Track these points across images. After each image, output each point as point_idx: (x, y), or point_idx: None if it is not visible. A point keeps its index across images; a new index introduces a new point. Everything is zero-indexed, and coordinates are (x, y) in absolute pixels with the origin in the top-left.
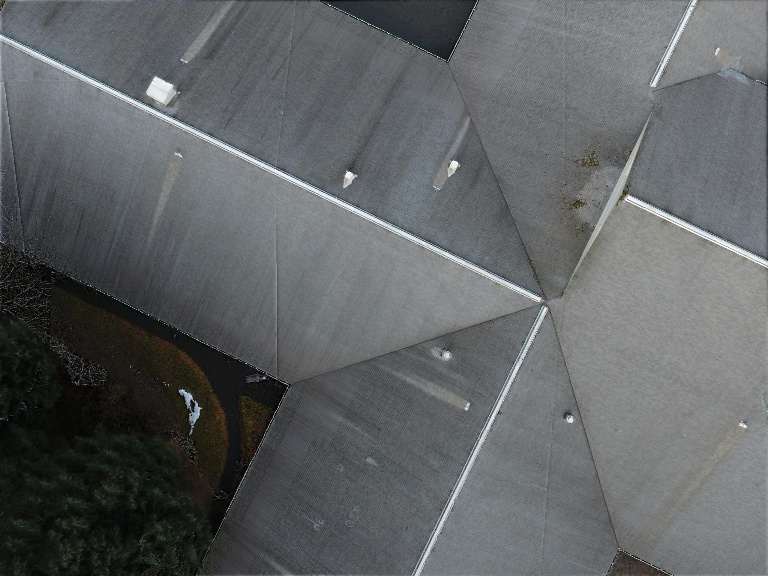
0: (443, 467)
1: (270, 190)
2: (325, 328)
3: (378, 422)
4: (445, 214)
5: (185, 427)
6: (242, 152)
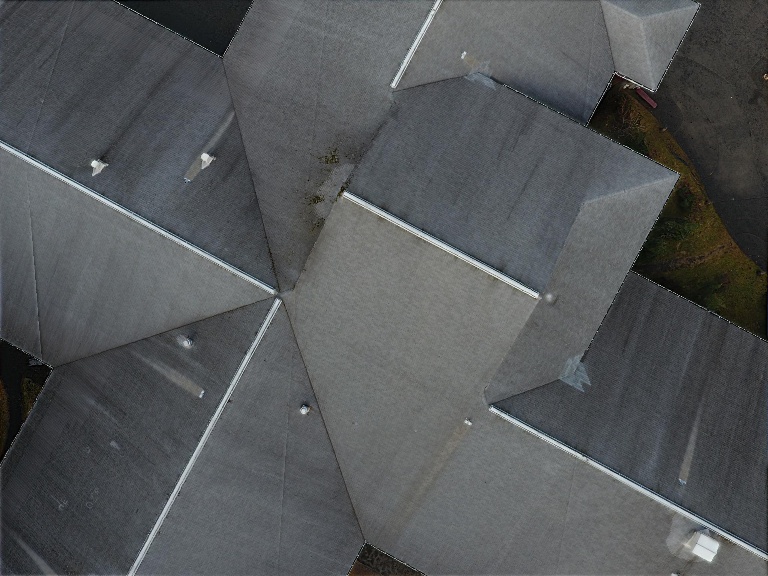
0: (174, 452)
1: (22, 176)
2: (81, 313)
3: (124, 407)
4: (191, 205)
5: None
6: None
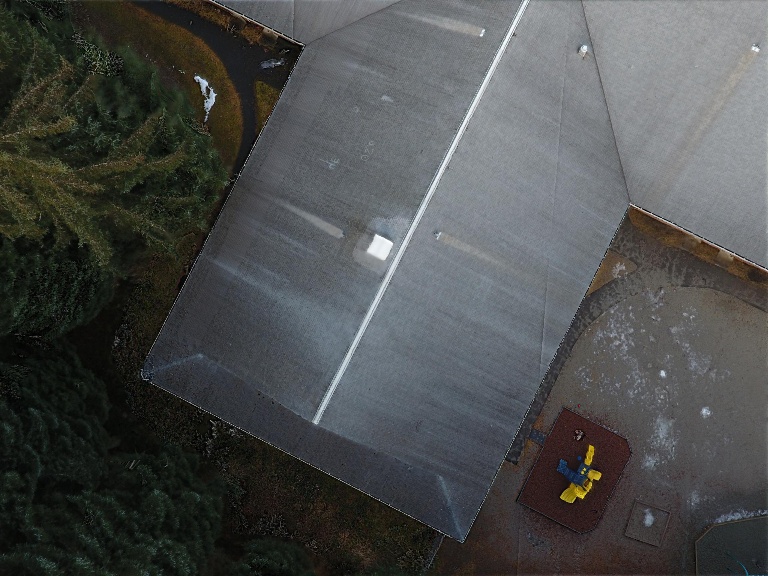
0: (458, 91)
1: None
2: None
3: (393, 62)
4: None
5: (200, 114)
6: None
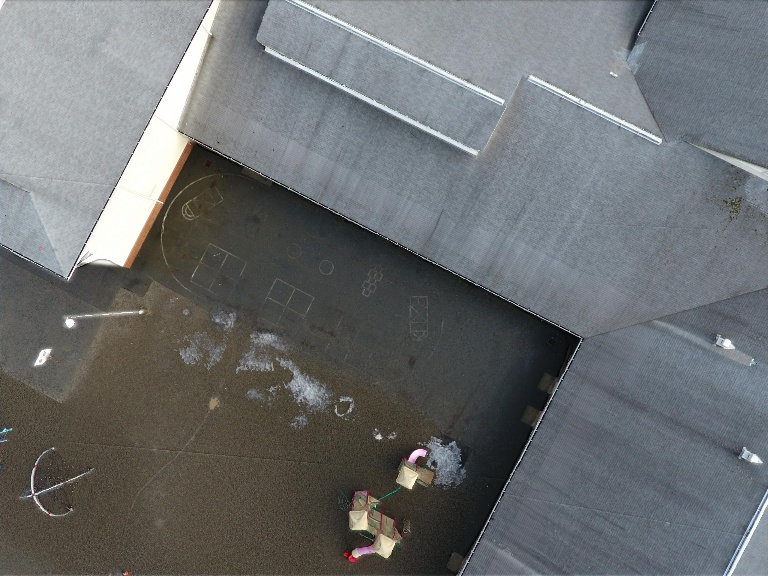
0: None
1: (763, 542)
2: None
3: None
4: None
5: None
6: (727, 572)
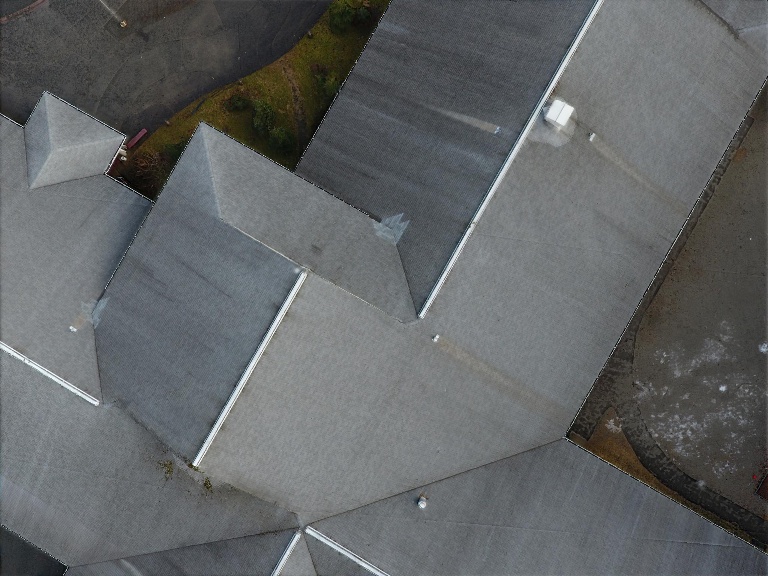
0: None
1: None
2: None
3: None
4: None
5: None
6: None
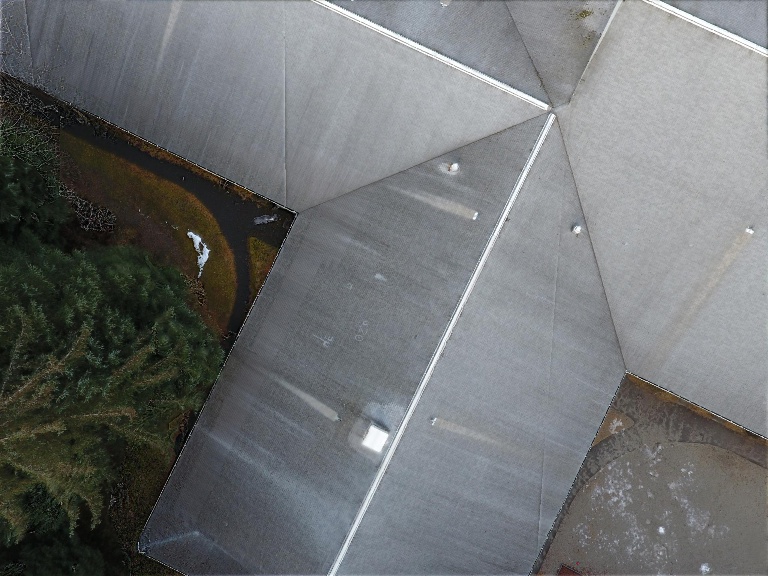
0: (452, 275)
1: (278, 4)
2: (333, 150)
3: (386, 239)
4: (452, 28)
5: (194, 270)
6: None
